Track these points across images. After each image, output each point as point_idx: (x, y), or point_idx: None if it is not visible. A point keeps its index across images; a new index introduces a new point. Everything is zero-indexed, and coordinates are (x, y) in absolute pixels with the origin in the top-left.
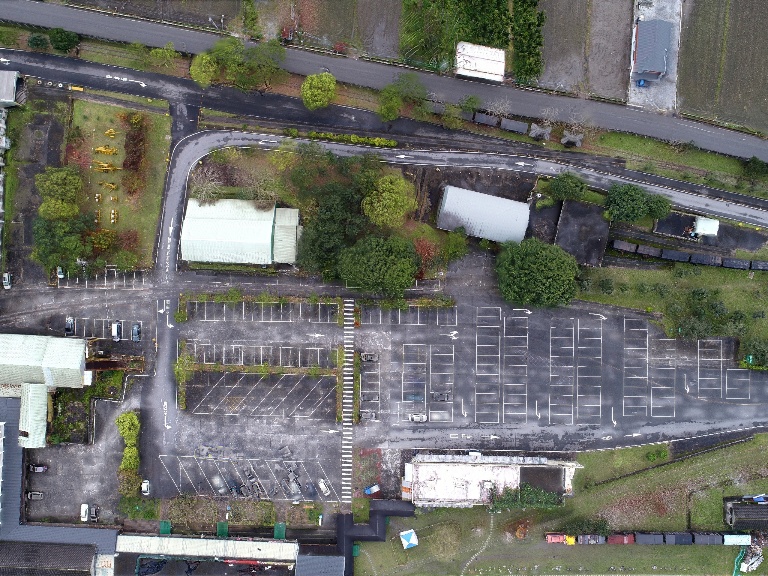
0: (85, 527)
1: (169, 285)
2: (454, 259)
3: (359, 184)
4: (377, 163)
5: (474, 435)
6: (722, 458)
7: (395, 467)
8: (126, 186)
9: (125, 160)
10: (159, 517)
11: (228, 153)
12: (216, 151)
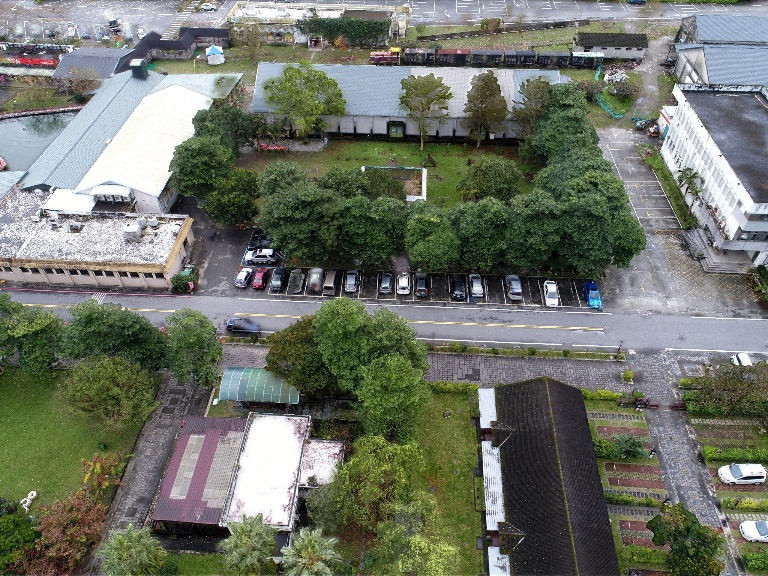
0: None
1: None
2: None
3: None
4: None
5: None
6: (561, 32)
7: None
8: None
9: None
10: None
11: None
12: None
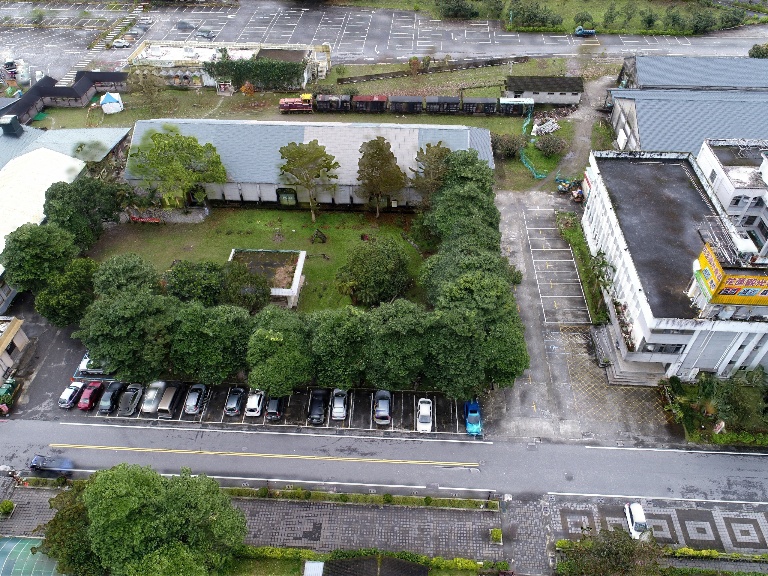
0: None
1: None
2: None
3: None
4: None
5: None
6: (496, 71)
7: None
8: None
9: None
10: None
11: None
12: None
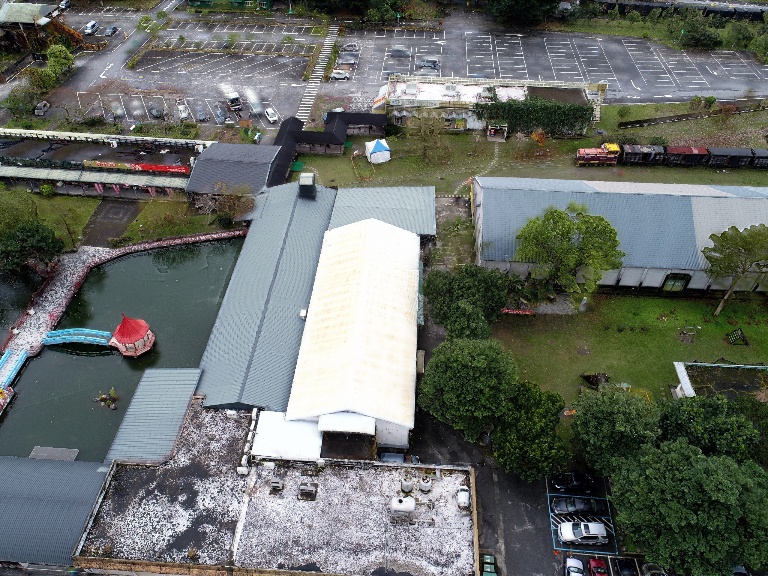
0: None
1: None
2: None
3: None
4: None
5: None
6: None
7: (367, 107)
8: None
9: None
10: None
11: None
12: None
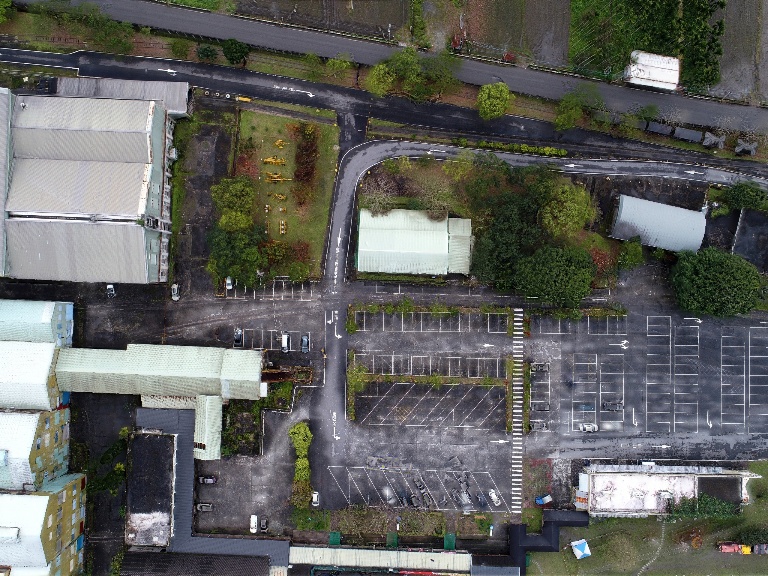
0: (256, 538)
1: (337, 296)
2: (624, 268)
3: (536, 194)
4: (550, 172)
5: (645, 445)
6: None
7: (566, 477)
8: (300, 197)
9: (299, 171)
10: (328, 528)
11: (396, 163)
12: (384, 161)
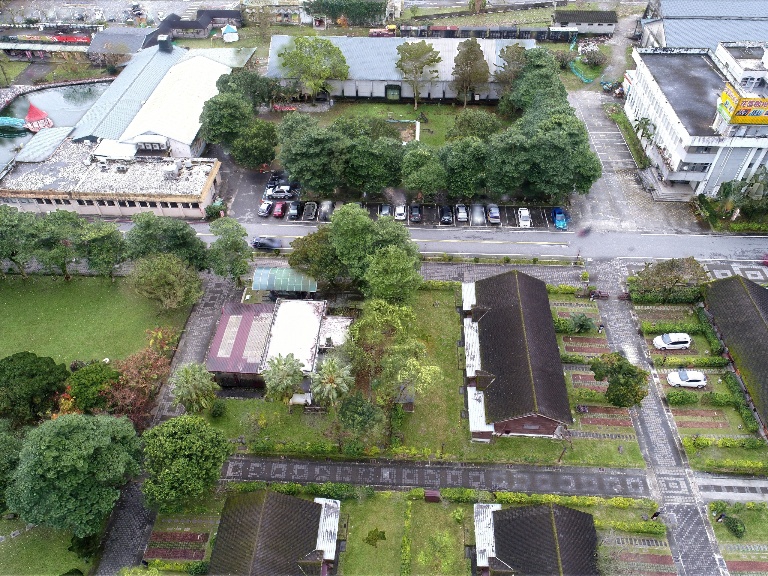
0: None
1: None
2: None
3: None
4: None
5: None
6: (541, 12)
7: None
8: None
9: None
10: None
11: None
12: None
